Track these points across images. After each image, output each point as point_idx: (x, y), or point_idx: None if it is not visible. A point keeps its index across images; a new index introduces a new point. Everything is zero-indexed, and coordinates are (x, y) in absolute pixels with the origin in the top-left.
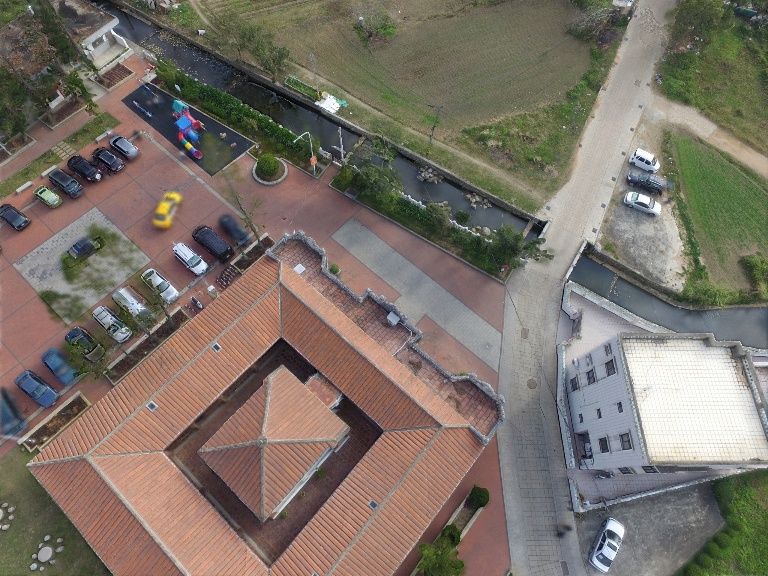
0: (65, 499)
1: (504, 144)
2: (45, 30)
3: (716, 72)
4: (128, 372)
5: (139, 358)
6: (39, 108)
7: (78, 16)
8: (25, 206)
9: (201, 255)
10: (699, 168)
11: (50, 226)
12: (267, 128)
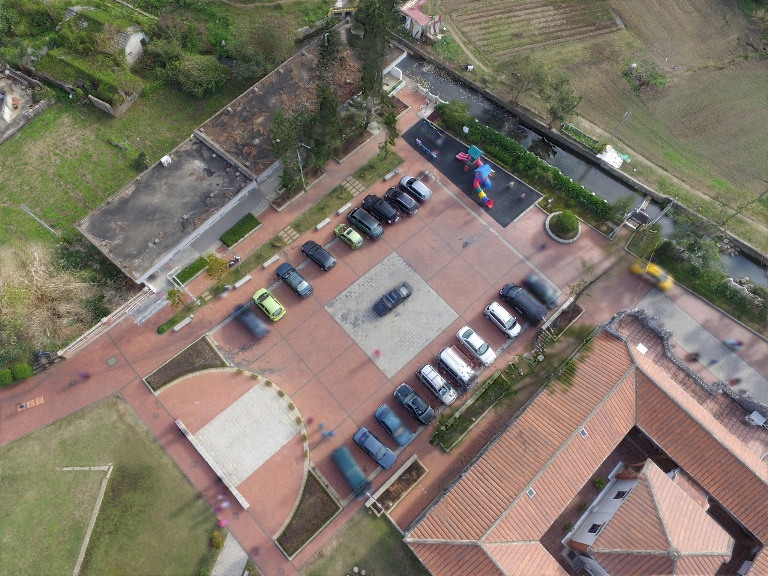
0: None
1: None
2: (366, 66)
3: None
4: (459, 438)
5: (468, 424)
6: None
7: None
8: (326, 244)
9: None
10: None
11: (354, 268)
12: (556, 180)
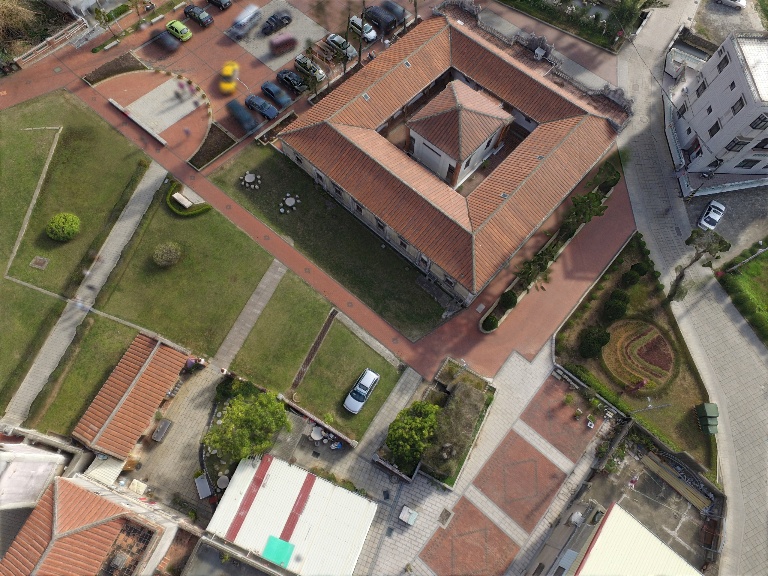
0: (310, 153)
1: None
2: None
3: None
4: None
5: None
6: None
7: None
8: None
9: (371, 26)
10: None
11: (246, 8)
12: None
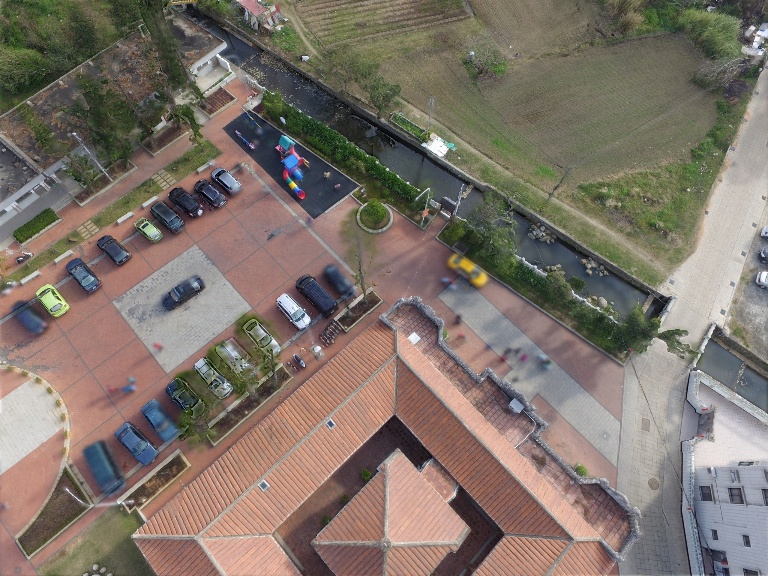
0: None
1: (623, 205)
2: (160, 57)
3: None
4: (228, 432)
5: (240, 417)
6: (143, 134)
7: (186, 37)
8: (125, 238)
9: (305, 308)
10: None
11: (150, 262)
12: (373, 170)
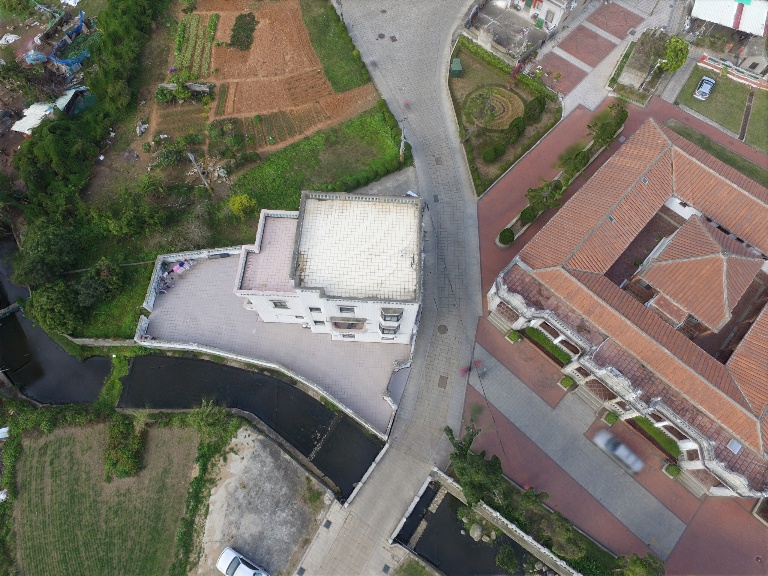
0: None
1: None
2: None
3: None
4: None
5: None
6: None
7: None
8: None
9: None
10: None
11: None
12: None
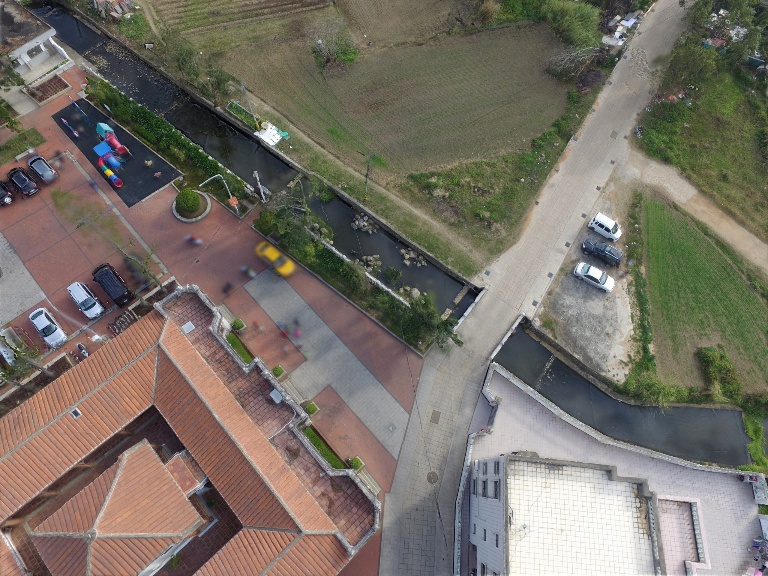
0: None
1: (451, 195)
2: None
3: (707, 127)
4: None
5: (11, 407)
6: None
7: (14, 24)
8: None
9: (97, 297)
10: (668, 239)
11: None
12: (196, 158)
